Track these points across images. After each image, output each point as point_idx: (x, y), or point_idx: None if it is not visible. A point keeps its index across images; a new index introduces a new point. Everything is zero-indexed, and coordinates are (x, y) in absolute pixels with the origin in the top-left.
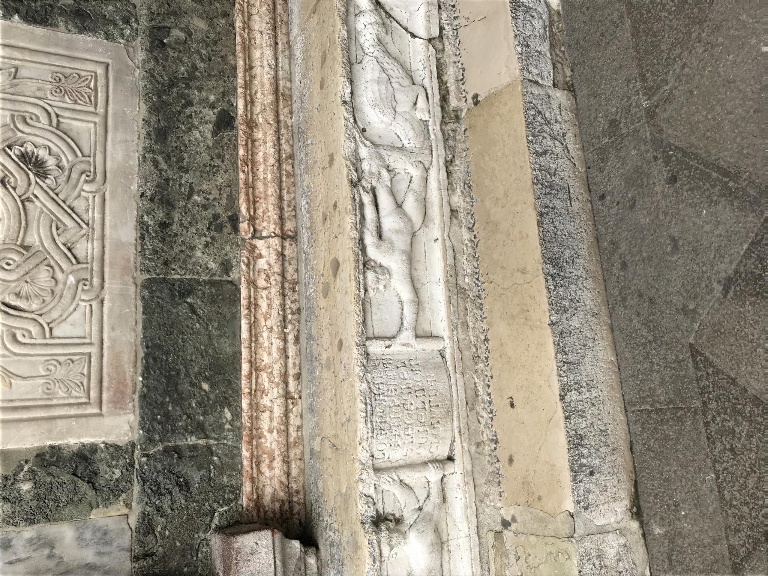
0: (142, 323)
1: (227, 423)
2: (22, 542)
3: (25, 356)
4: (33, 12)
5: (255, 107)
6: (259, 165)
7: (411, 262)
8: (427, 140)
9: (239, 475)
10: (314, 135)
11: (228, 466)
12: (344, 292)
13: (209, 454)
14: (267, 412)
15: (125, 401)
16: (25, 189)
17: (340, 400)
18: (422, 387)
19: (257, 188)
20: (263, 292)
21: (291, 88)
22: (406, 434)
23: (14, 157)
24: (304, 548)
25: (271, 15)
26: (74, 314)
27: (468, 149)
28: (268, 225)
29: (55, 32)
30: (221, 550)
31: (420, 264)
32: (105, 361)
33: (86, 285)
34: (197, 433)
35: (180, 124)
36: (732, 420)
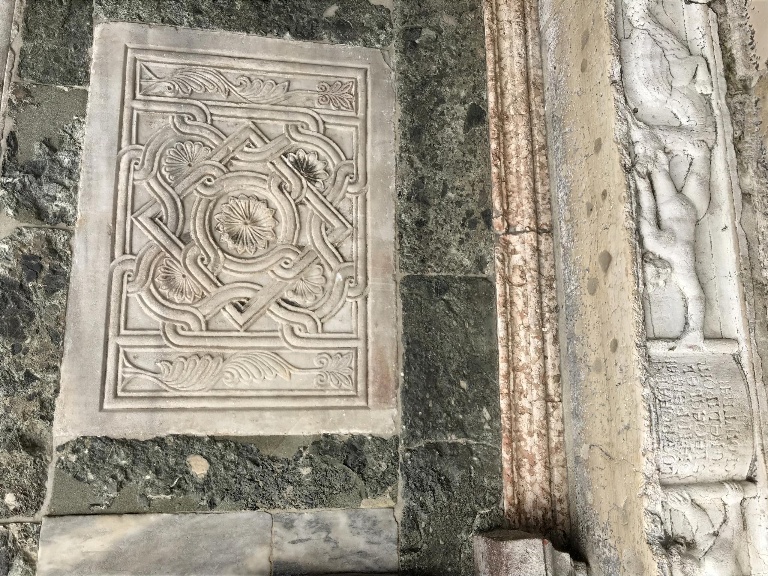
0: (402, 320)
1: (486, 423)
2: (302, 524)
3: (301, 349)
4: (301, 28)
5: (505, 99)
6: (511, 158)
7: (695, 254)
8: (710, 116)
9: (499, 478)
10: (574, 121)
11: (488, 468)
12: (619, 288)
13: (469, 454)
14: (526, 414)
15: (389, 396)
16: (298, 193)
17: (615, 406)
18: (715, 395)
19: (510, 182)
20: (519, 289)
21: (543, 76)
22: (697, 448)
23: (289, 164)
24: (573, 562)
25: (520, 2)
26: (342, 310)
27: (761, 122)
28: (522, 220)
29: (320, 44)
30: (487, 554)
31: (705, 256)
32: (370, 356)
33: (352, 282)
34: (457, 432)
35: (433, 122)
36: None
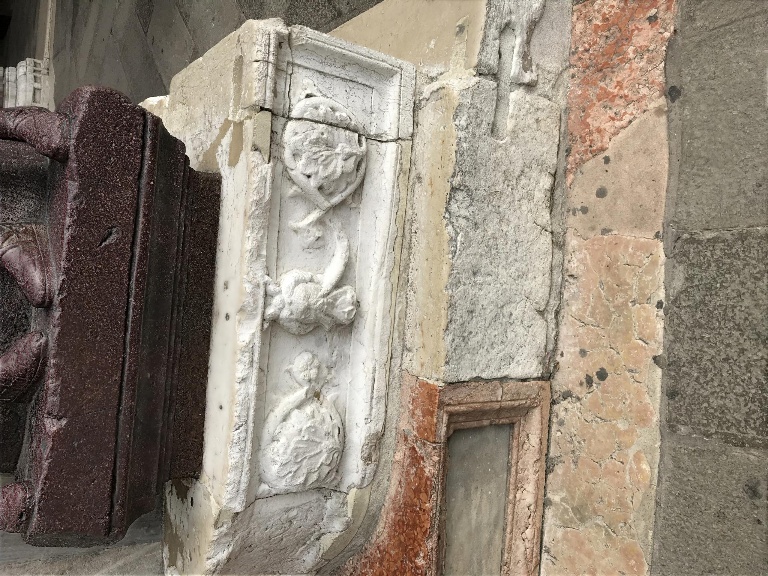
0: None
1: None
2: None
3: None
4: None
5: None
6: None
7: None
8: None
9: None
10: None
11: None
12: None
13: None
14: None
15: None
16: None
17: None
18: None
19: None
20: None
21: None
22: None
23: None
24: None
25: None
26: None
27: None
28: None
29: None
30: None
31: None
32: None
33: None
34: None
35: None
36: (291, 24)
